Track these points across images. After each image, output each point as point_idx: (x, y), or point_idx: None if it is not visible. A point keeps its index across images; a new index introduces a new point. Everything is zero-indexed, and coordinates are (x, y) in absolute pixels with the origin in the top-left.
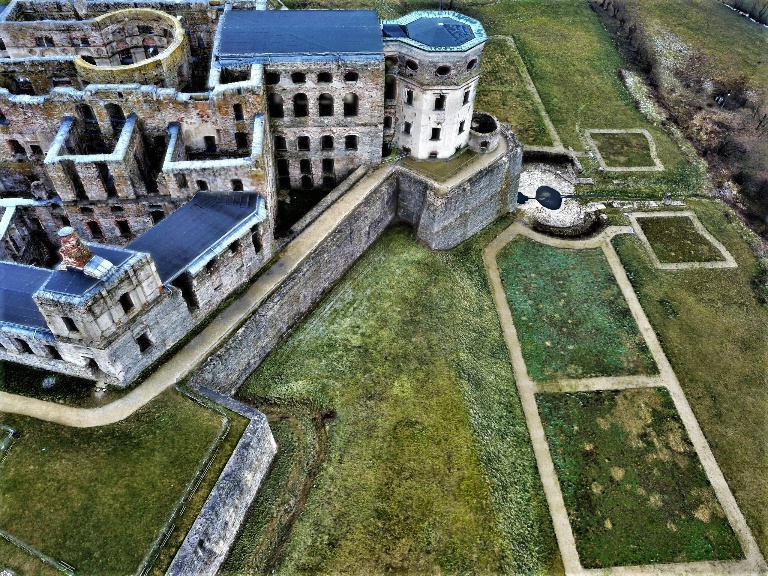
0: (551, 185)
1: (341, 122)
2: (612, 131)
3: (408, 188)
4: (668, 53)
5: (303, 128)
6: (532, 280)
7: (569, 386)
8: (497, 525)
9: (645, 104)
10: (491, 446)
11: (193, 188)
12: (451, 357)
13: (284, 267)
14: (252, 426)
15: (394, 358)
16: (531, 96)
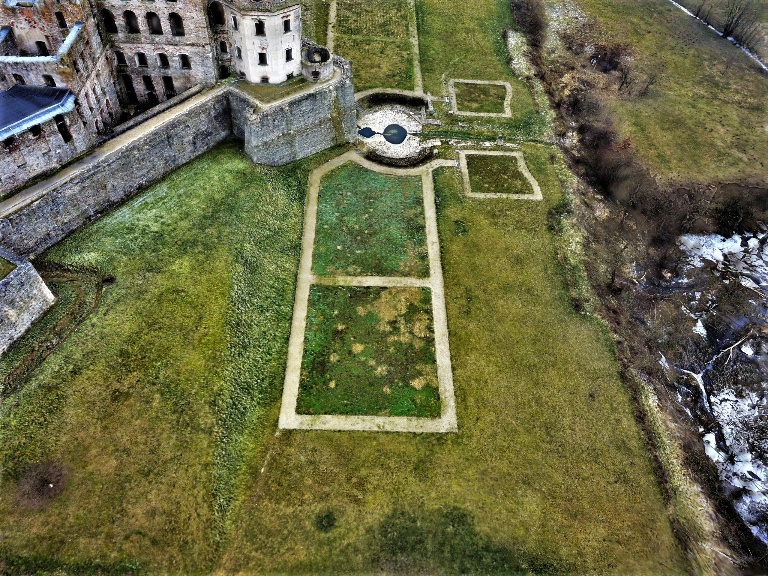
0: (401, 124)
1: (171, 41)
2: (476, 82)
3: (237, 107)
4: (563, 19)
5: (137, 44)
6: (346, 197)
7: (344, 281)
8: (223, 371)
9: (518, 61)
10: (245, 315)
11: (11, 81)
12: (235, 246)
13: (95, 159)
14: (17, 270)
15: (183, 242)
16: (411, 47)
